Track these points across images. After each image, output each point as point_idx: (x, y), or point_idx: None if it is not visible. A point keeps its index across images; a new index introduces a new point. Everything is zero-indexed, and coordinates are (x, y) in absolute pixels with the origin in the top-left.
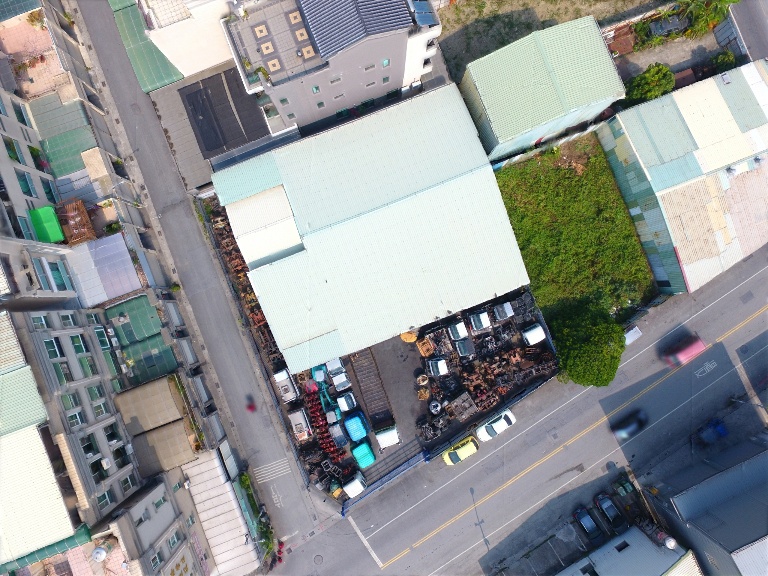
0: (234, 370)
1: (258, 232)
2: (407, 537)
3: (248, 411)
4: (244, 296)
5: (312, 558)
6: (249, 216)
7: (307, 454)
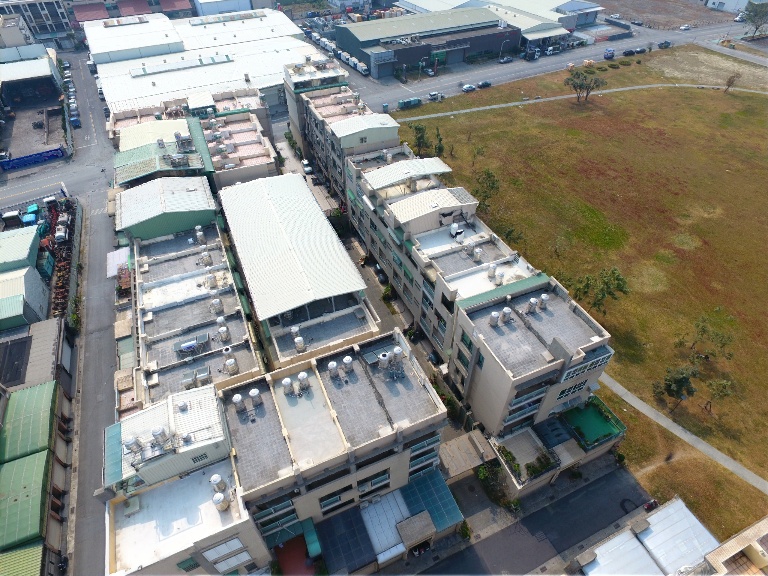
0: (102, 248)
1: (5, 280)
2: (40, 191)
3: (103, 232)
4: (67, 275)
5: (99, 184)
6: (7, 290)
7: (72, 213)
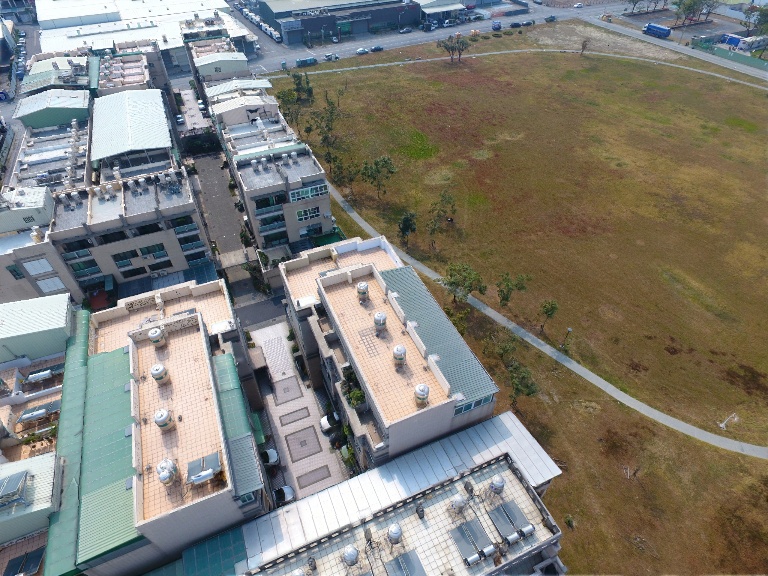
0: None
1: None
2: None
3: None
4: None
5: None
6: None
7: (4, 134)
